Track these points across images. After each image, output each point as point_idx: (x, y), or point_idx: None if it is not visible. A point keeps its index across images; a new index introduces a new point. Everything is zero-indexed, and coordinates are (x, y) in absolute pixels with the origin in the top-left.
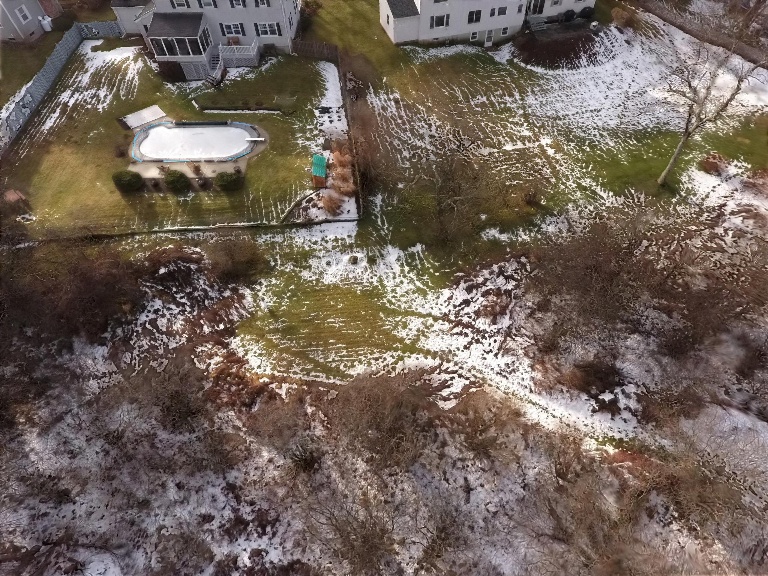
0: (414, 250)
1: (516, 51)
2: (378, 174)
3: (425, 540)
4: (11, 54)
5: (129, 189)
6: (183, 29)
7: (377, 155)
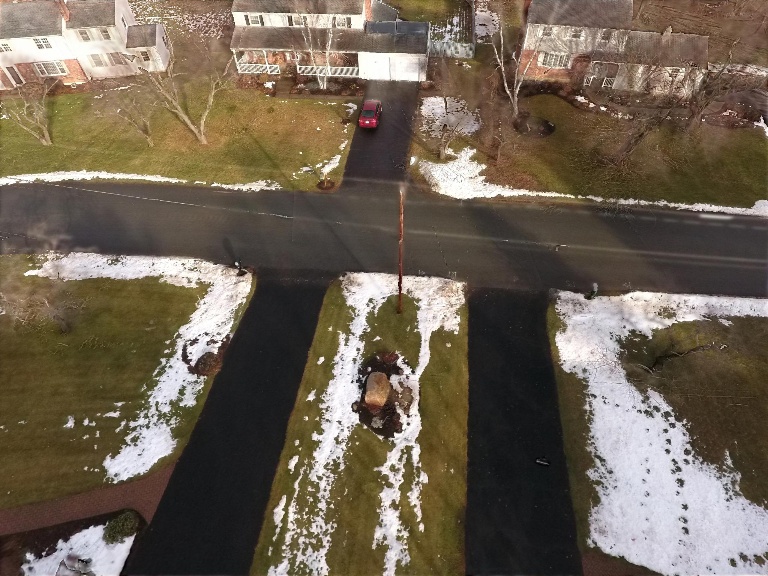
0: None
1: None
2: None
3: None
4: None
5: None
6: None
7: None
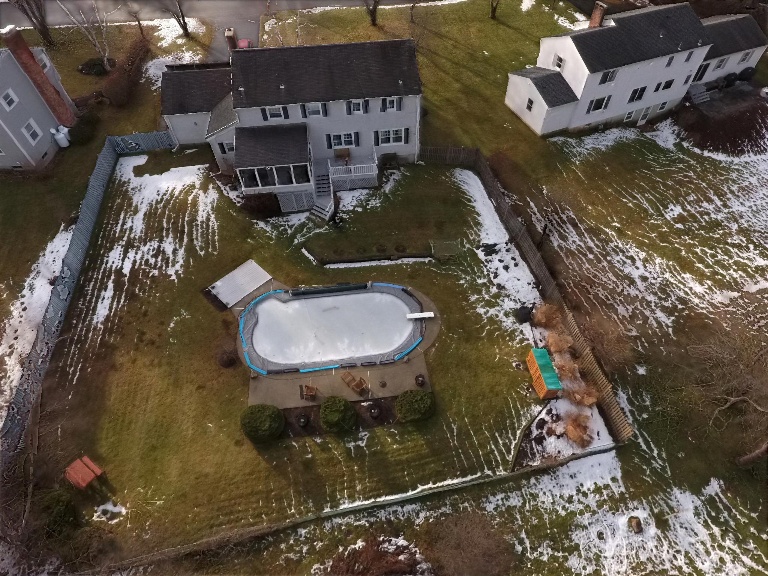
0: (711, 492)
1: (682, 132)
2: (606, 355)
3: None
4: (19, 191)
5: (268, 439)
6: (285, 152)
7: (586, 318)
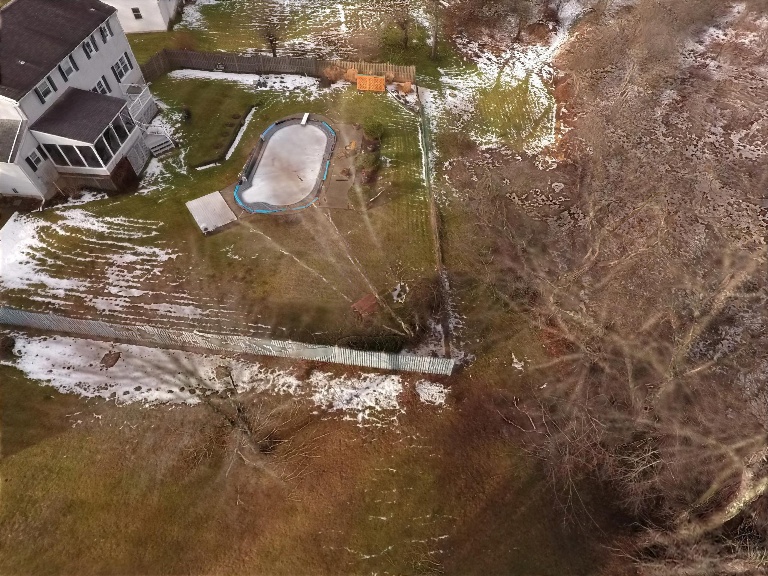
0: (443, 72)
1: None
2: None
3: (635, 87)
4: None
5: None
6: (99, 109)
7: None
